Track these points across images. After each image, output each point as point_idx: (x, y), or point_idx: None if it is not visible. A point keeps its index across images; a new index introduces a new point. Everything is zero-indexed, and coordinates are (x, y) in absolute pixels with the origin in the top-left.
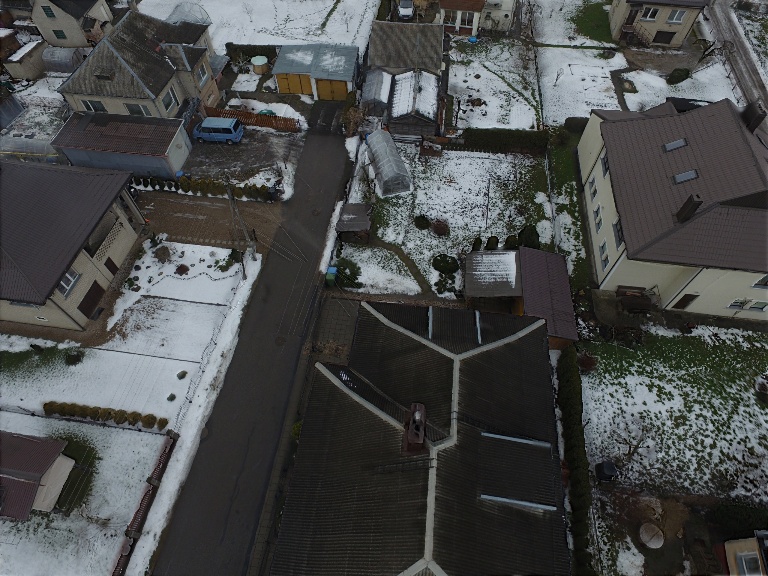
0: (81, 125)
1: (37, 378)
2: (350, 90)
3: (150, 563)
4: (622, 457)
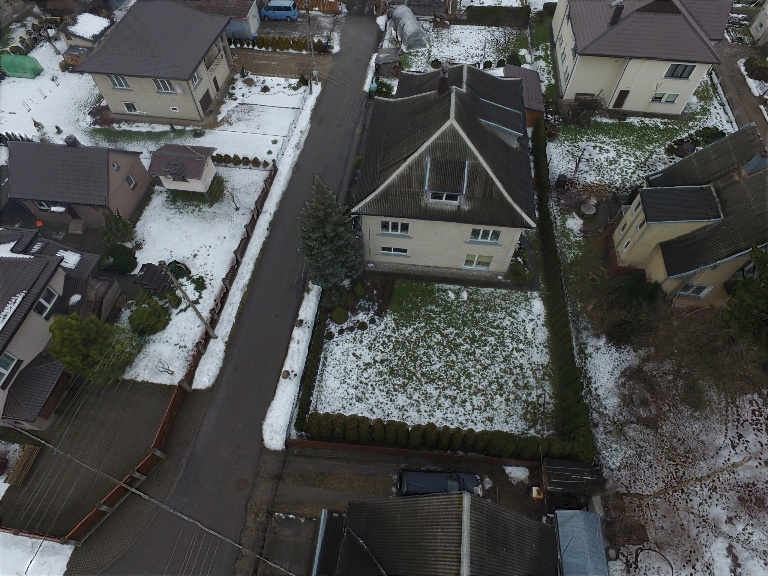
0: (181, 0)
1: None
2: None
3: (269, 225)
4: (573, 179)
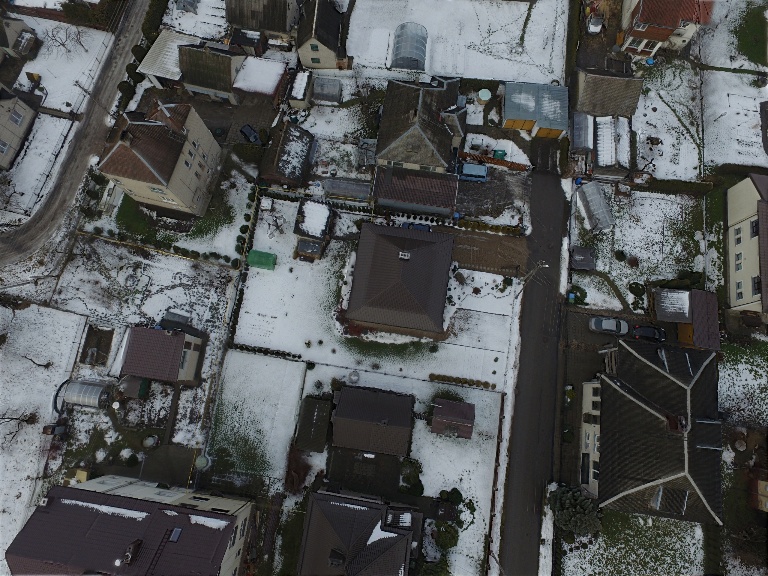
0: (387, 178)
1: (418, 360)
2: (563, 134)
3: (508, 452)
4: (731, 408)
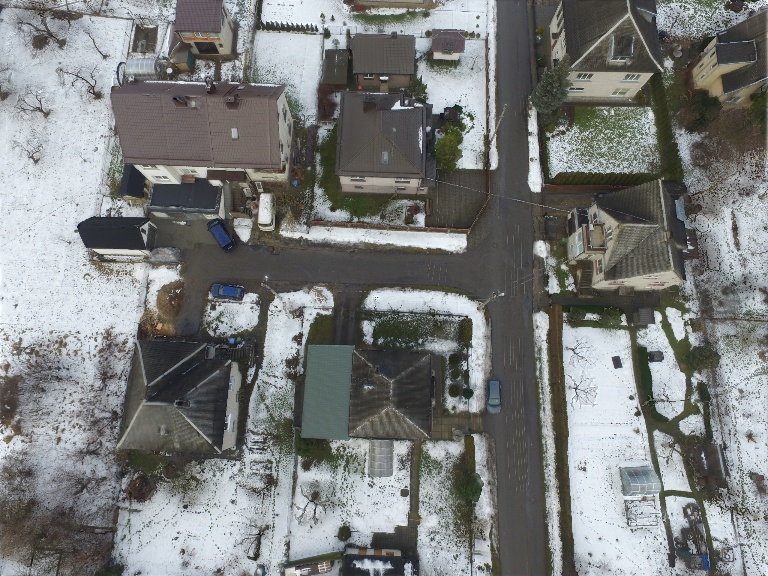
0: None
1: (414, 23)
2: None
3: (495, 78)
4: (668, 32)
